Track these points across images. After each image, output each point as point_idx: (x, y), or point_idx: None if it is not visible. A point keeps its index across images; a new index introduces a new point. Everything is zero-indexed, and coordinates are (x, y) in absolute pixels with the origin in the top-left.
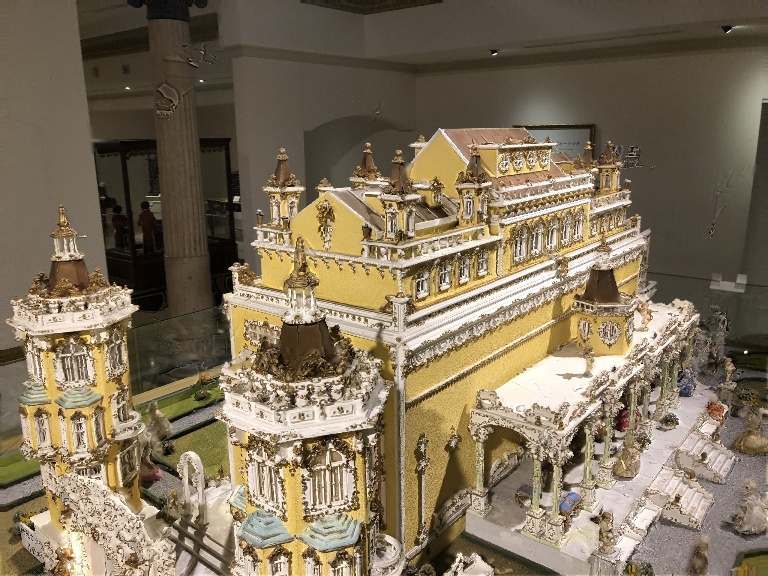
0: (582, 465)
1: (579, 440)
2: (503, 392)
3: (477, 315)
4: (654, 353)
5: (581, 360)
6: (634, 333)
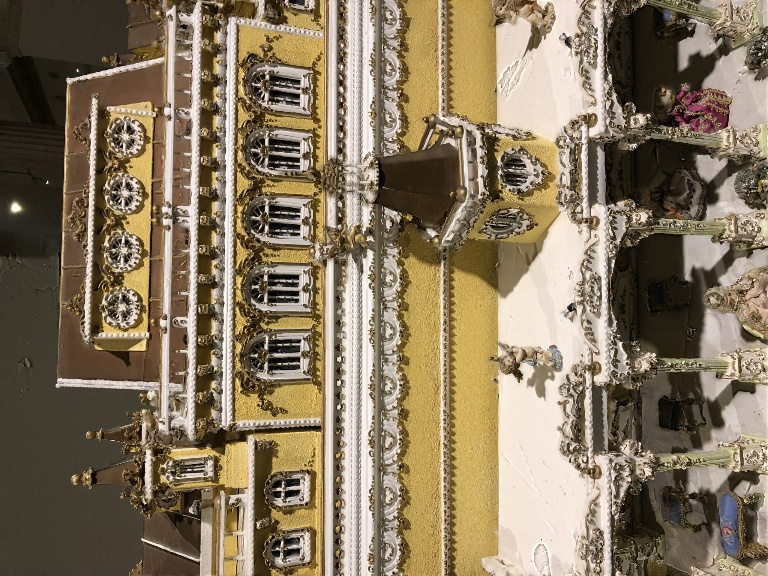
0: (705, 327)
1: (665, 295)
2: (506, 511)
3: (365, 571)
4: (598, 129)
5: (530, 288)
6: (544, 57)
